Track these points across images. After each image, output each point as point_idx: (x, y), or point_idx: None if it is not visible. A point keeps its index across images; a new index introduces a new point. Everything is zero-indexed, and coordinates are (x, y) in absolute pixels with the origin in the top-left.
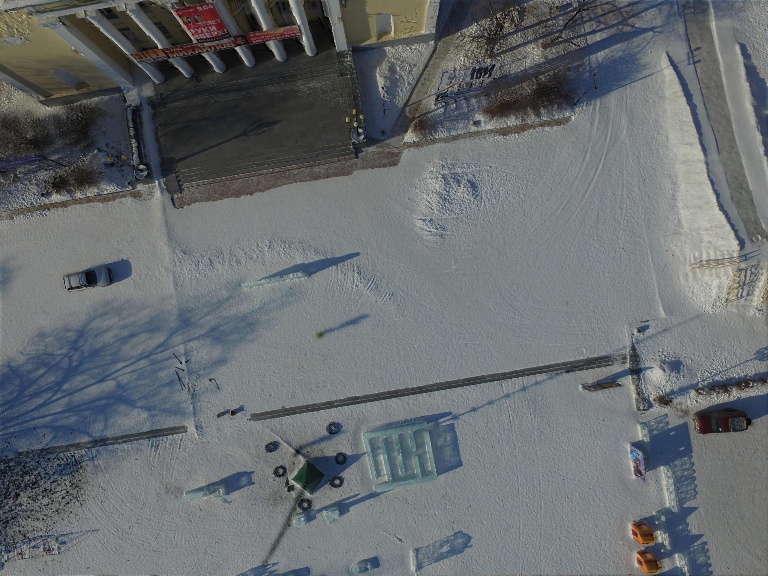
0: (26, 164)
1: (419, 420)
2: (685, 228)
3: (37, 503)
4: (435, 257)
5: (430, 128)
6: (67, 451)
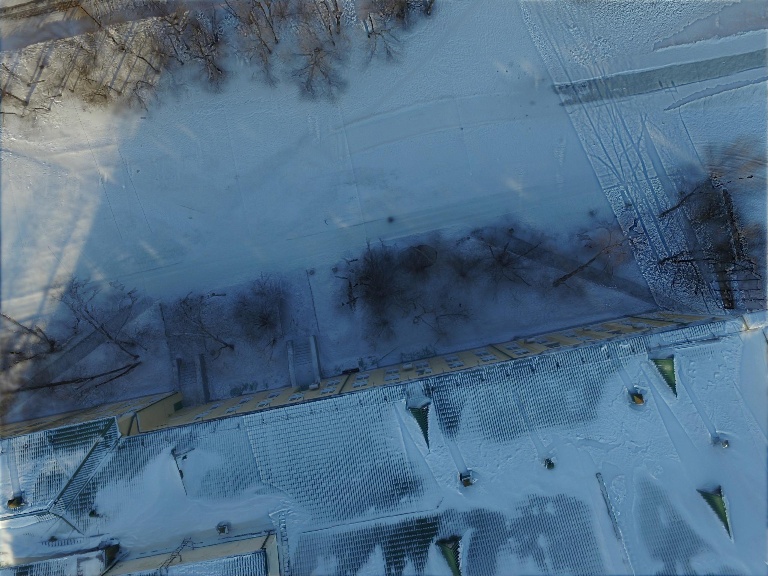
0: None
1: None
2: None
3: None
4: None
5: (742, 312)
6: None
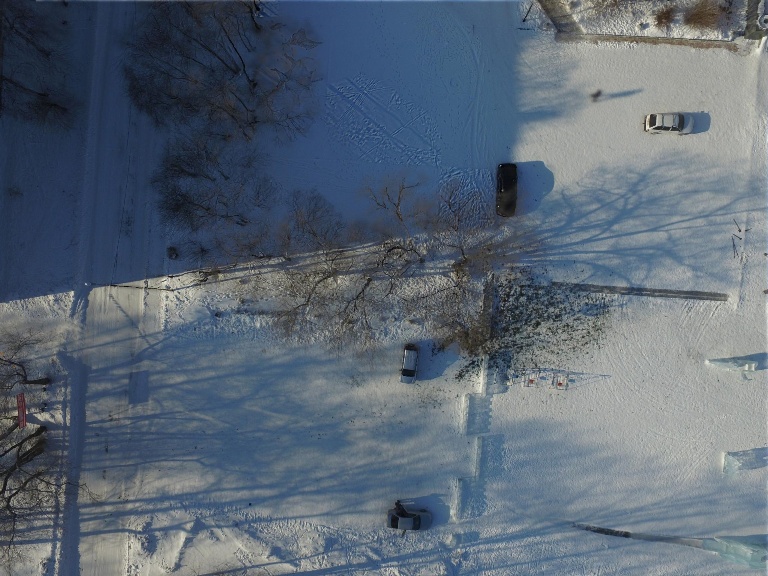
0: None
1: None
2: None
3: (556, 336)
4: None
5: None
6: (600, 292)
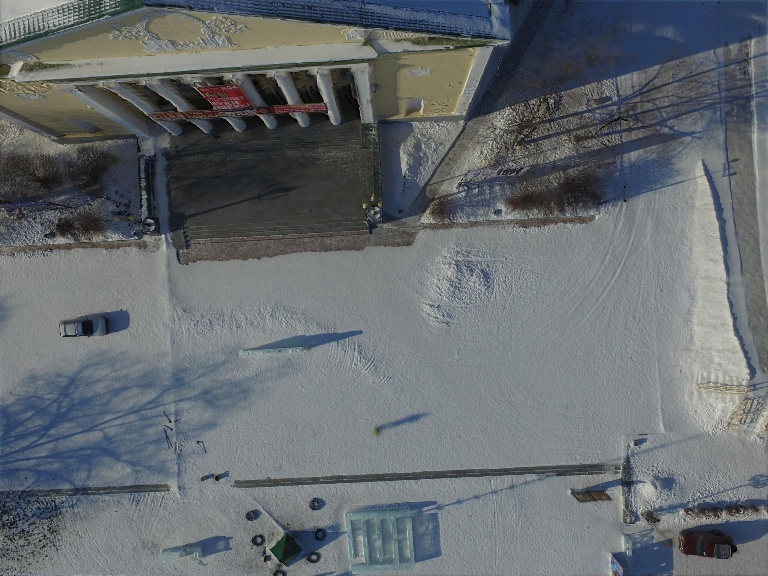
0: (31, 206)
1: (403, 506)
2: (697, 346)
3: (13, 543)
4: (438, 344)
5: (449, 212)
6: (48, 496)
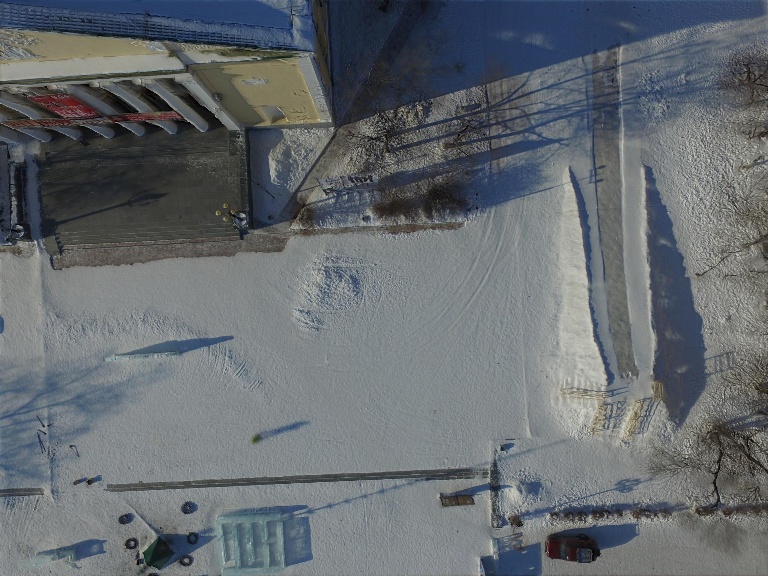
0: None
1: (274, 510)
2: (562, 351)
3: None
4: (308, 350)
5: (318, 218)
6: None
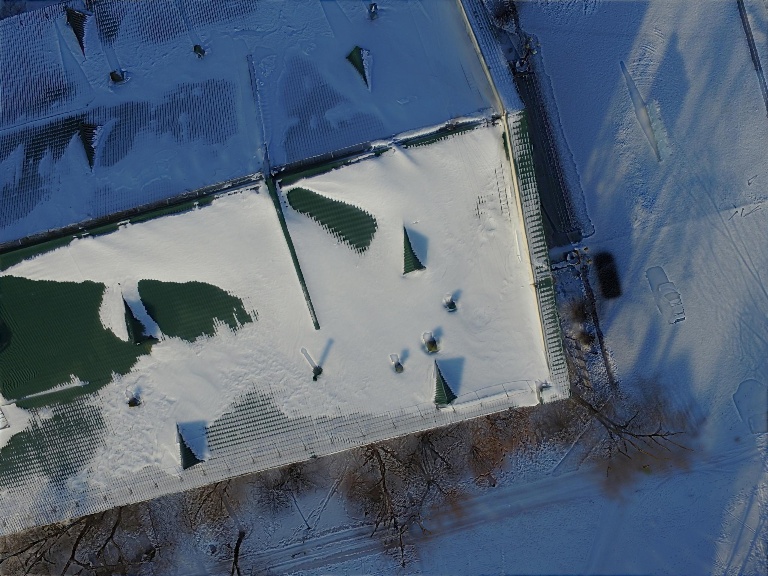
0: None
1: None
2: None
3: None
4: None
5: (503, 8)
6: None
